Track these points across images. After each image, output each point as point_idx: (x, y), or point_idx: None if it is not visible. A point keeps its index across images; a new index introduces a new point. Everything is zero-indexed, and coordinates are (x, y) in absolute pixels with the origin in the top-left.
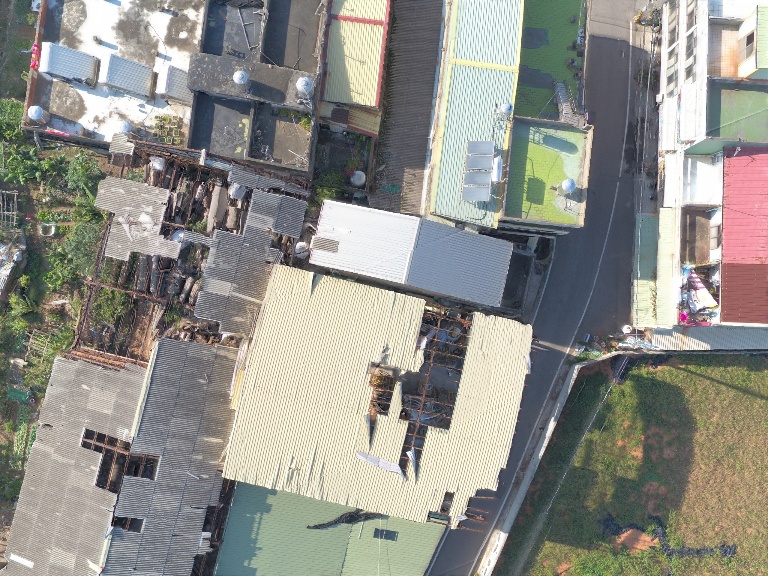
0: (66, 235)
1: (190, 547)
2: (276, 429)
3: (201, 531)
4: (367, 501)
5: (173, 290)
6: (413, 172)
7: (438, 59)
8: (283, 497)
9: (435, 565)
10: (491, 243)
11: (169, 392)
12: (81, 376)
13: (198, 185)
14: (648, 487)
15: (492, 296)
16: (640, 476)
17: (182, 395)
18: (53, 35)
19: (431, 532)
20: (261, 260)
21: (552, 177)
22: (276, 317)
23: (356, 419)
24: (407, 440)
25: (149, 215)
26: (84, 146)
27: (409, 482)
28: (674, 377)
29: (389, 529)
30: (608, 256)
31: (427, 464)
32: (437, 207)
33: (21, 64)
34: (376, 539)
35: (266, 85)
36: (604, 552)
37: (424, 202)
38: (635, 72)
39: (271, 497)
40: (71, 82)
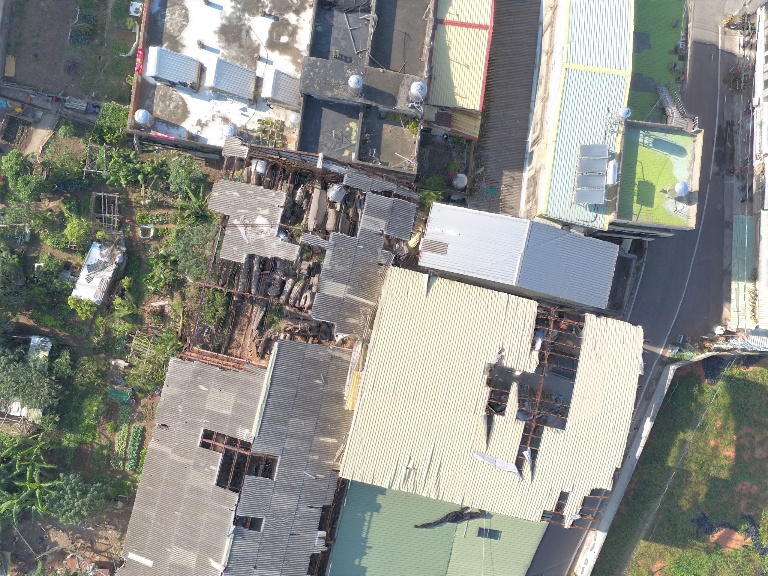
0: (164, 237)
1: (306, 546)
2: (394, 429)
3: (317, 530)
4: (482, 500)
5: (274, 292)
6: (512, 175)
7: (536, 63)
8: (392, 496)
9: (532, 564)
10: (598, 245)
11: (288, 393)
12: (198, 377)
13: (298, 188)
14: (741, 487)
15: (599, 298)
16: (733, 476)
17: (300, 396)
18: (156, 39)
19: (533, 531)
20: (374, 262)
21: (662, 180)
22: (393, 318)
23: (473, 419)
24: (523, 440)
25: (266, 218)
26: (182, 149)
27: (525, 482)
28: (766, 378)
29: (493, 528)
30: (699, 258)
31: (543, 464)
32: (548, 210)
33: (119, 68)
34: (480, 538)
35: (377, 89)
36: (698, 551)
37: (523, 204)
38: (724, 76)
39: (380, 496)
40: (175, 86)
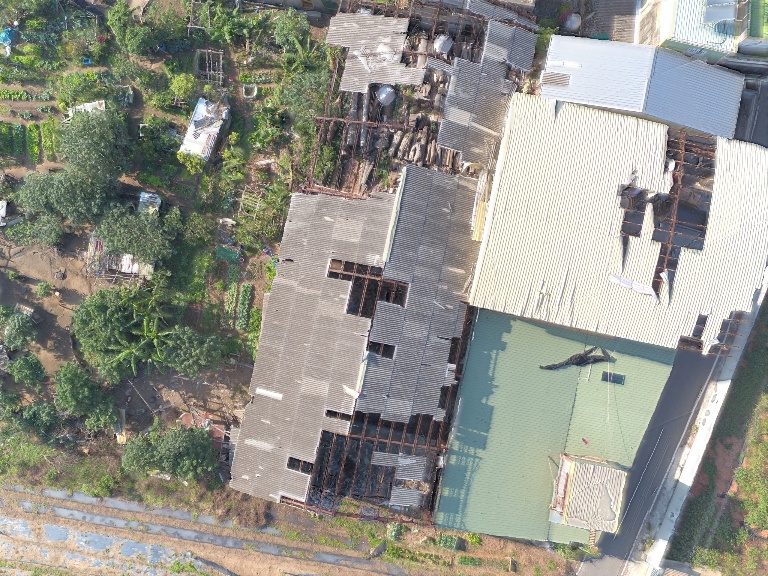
0: (268, 96)
1: (437, 378)
2: (527, 252)
3: (447, 362)
4: (617, 326)
5: (383, 144)
6: (624, 18)
7: None
8: (517, 335)
9: (652, 417)
10: (724, 73)
11: (417, 219)
12: (323, 209)
13: None
14: None
15: (726, 127)
16: None
17: (428, 223)
18: None
19: (657, 376)
20: (497, 91)
21: None
22: (523, 141)
23: (608, 241)
24: (660, 262)
25: (388, 45)
26: (283, 7)
27: (661, 305)
28: None
29: (616, 372)
30: None
31: (680, 286)
32: (676, 32)
33: None
34: (604, 382)
35: None
36: None
37: None
38: None
39: (506, 335)
40: None
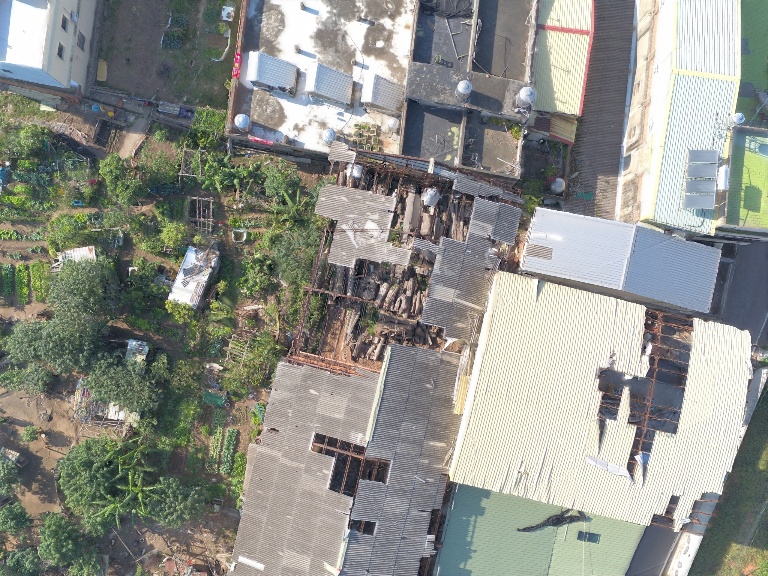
0: (257, 241)
1: (416, 550)
2: (507, 433)
3: (426, 534)
4: (593, 504)
5: (369, 296)
6: (606, 179)
7: (630, 68)
8: (495, 500)
9: None
10: (701, 250)
11: (400, 397)
12: (308, 381)
13: (392, 192)
14: None
15: (702, 302)
16: None
17: (411, 400)
18: (253, 44)
19: (631, 535)
20: (481, 267)
21: None
22: (505, 323)
23: (585, 424)
24: (635, 444)
25: (376, 222)
26: None
27: (636, 486)
28: None
29: (592, 532)
30: None
31: (654, 468)
32: (656, 215)
33: (211, 72)
34: (580, 542)
35: (484, 94)
36: None
37: (619, 209)
38: None
39: (485, 500)
40: (272, 91)
